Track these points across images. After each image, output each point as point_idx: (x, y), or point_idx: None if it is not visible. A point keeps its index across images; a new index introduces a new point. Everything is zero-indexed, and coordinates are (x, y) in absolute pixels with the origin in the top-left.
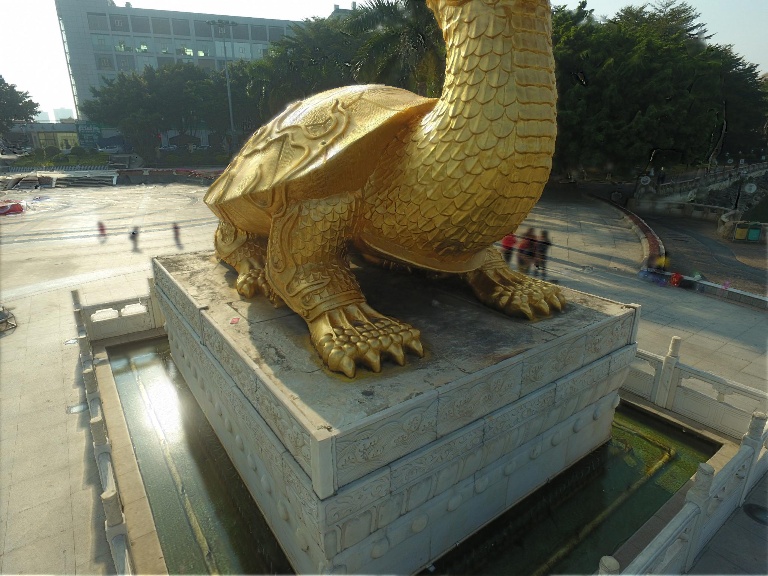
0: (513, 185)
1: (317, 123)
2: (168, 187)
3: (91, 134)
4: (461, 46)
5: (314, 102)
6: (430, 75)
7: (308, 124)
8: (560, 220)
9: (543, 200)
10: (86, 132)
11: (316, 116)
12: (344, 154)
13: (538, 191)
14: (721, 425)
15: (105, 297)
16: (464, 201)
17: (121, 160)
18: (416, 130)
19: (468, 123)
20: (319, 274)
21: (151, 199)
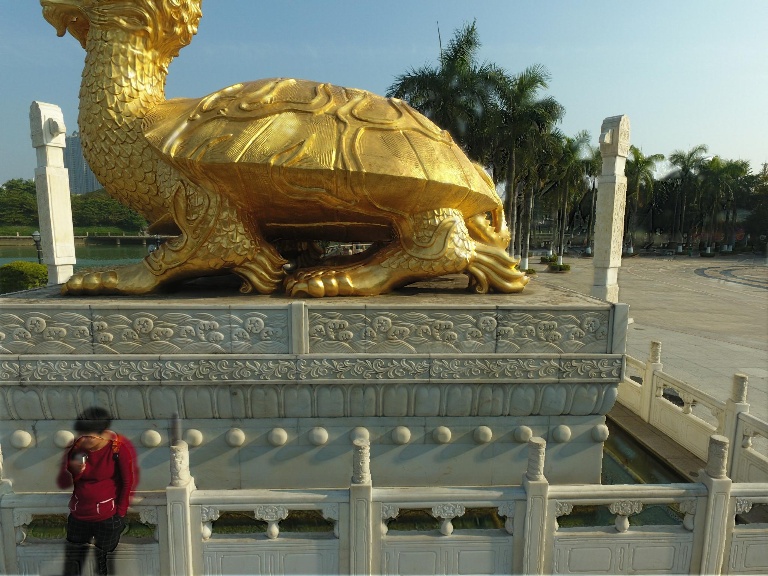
0: None
1: None
2: None
3: None
4: None
5: None
6: None
7: None
8: None
9: None
10: None
11: None
12: None
13: None
14: None
15: (678, 349)
16: None
17: None
18: None
19: None
20: None
21: None
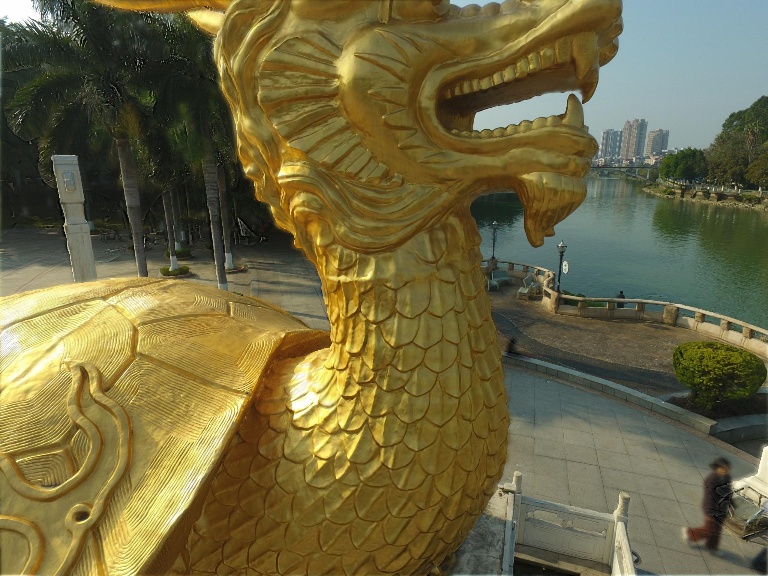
0: None
1: (44, 445)
2: None
3: None
4: (382, 323)
5: (15, 368)
6: (132, 131)
7: (17, 450)
8: (303, 278)
9: (276, 251)
10: None
11: (35, 422)
12: (156, 560)
13: None
14: (569, 549)
15: None
16: (415, 568)
17: None
18: (286, 433)
19: (418, 458)
20: None
21: None
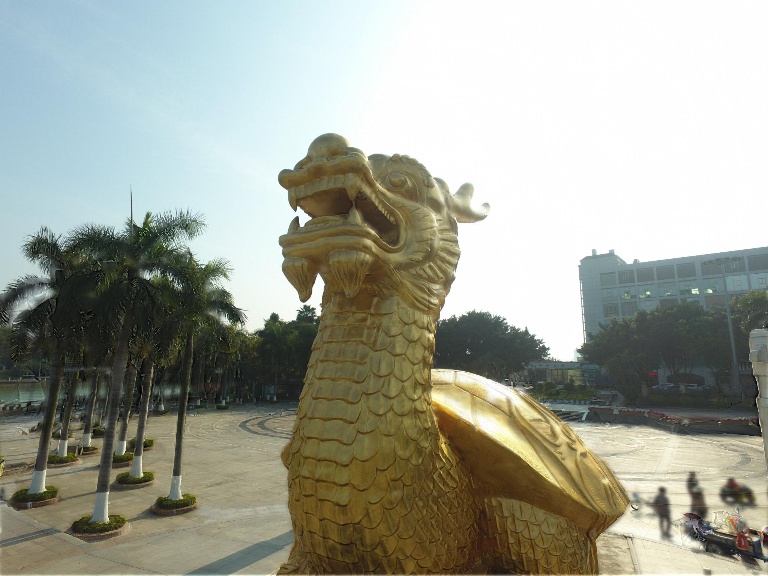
0: (308, 515)
1: None
2: (631, 429)
3: (583, 372)
4: None
5: None
6: None
7: None
8: None
9: None
10: (579, 370)
11: None
12: None
13: (340, 535)
14: None
15: None
16: None
17: (604, 397)
18: None
19: None
20: (297, 559)
21: (597, 440)
